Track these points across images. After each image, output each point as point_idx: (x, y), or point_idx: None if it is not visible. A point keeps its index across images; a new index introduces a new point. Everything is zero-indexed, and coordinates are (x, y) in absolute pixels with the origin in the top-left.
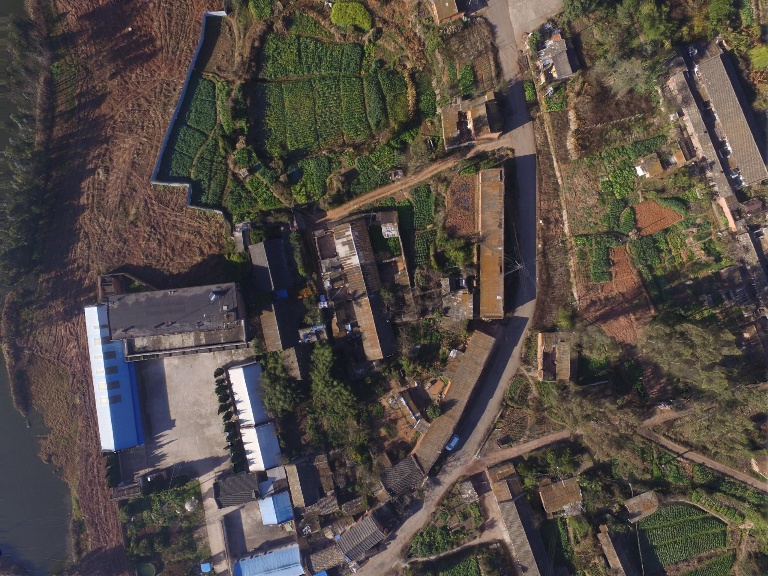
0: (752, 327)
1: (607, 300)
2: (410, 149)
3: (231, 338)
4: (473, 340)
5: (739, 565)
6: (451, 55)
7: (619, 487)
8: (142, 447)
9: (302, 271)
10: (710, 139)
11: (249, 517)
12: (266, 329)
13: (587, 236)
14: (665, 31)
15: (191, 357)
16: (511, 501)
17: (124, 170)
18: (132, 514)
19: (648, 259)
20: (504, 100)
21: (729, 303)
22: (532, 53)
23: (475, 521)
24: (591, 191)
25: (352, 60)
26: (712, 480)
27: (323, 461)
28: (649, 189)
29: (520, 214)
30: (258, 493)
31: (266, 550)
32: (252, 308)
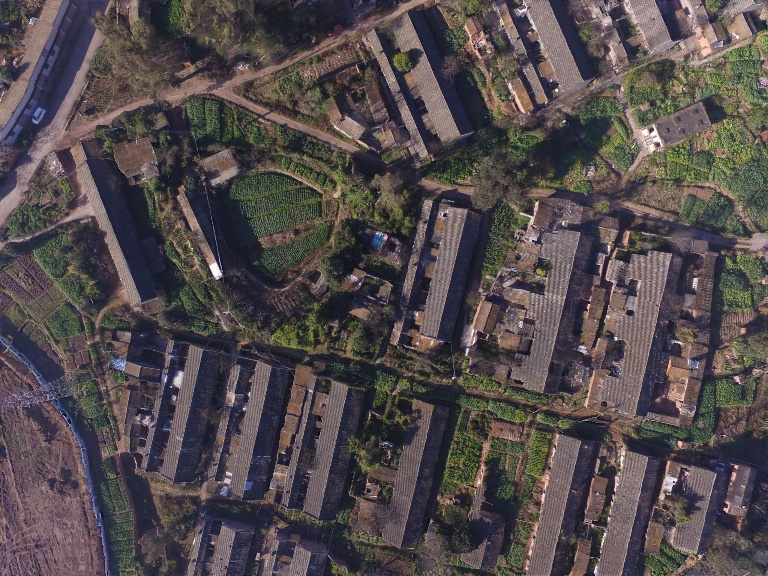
0: None
1: None
2: None
3: None
4: (47, 3)
5: None
6: None
7: (188, 140)
8: None
9: None
10: None
11: None
12: None
13: None
14: None
15: None
16: (83, 161)
17: None
18: None
19: None
20: None
21: None
22: None
23: (66, 197)
24: None
25: None
26: (294, 140)
27: None
28: None
29: None
30: None
31: None
32: None
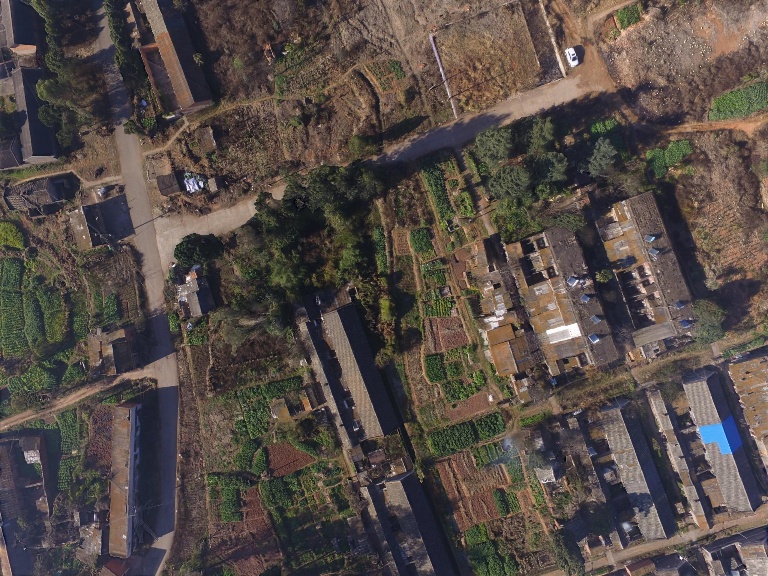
0: None
1: (238, 540)
2: (11, 403)
3: None
4: (101, 575)
5: None
6: (97, 282)
7: None
8: None
9: None
10: (331, 392)
11: None
12: None
13: (219, 475)
14: (291, 279)
15: None
16: None
17: None
18: None
19: (278, 502)
20: (148, 330)
21: (352, 553)
22: (171, 288)
23: None
24: (226, 429)
25: (12, 275)
26: None
27: None
28: (284, 430)
29: (161, 445)
30: None
31: None
32: None
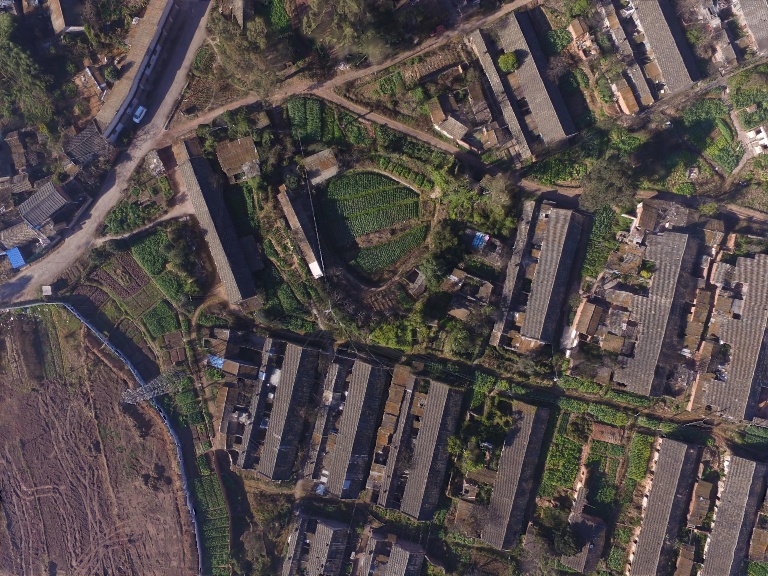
0: None
1: None
2: None
3: None
4: (151, 3)
5: (431, 235)
6: None
7: (291, 139)
8: None
9: None
10: None
11: None
12: None
13: None
14: None
15: None
16: None
17: None
18: None
19: None
20: None
21: None
22: None
23: (165, 195)
24: None
25: None
26: (394, 140)
27: (14, 137)
28: None
29: None
30: None
31: None
32: None
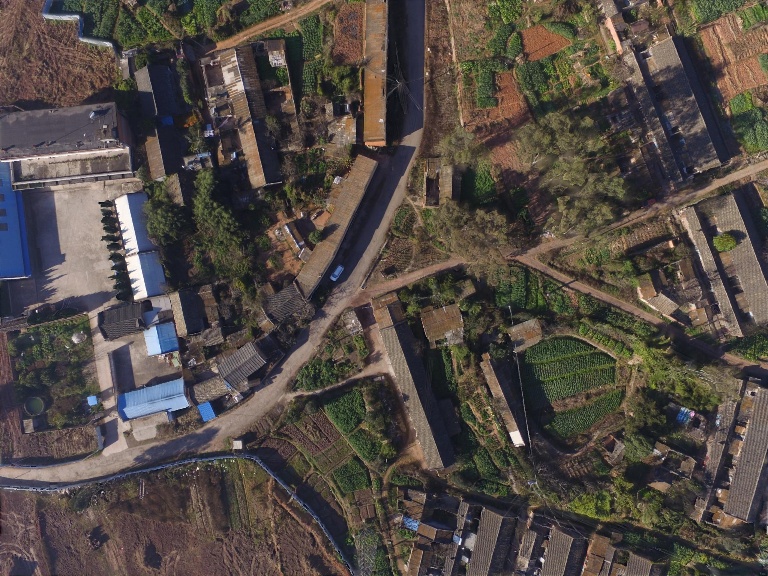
0: (637, 150)
1: (493, 126)
2: None
3: (117, 167)
4: (356, 165)
5: (627, 401)
6: None
7: (499, 311)
8: (32, 282)
9: (187, 97)
10: None
11: (138, 353)
12: (150, 156)
13: (473, 61)
14: None
15: (81, 191)
16: (391, 326)
17: (19, 6)
18: (21, 347)
19: (534, 84)
20: None
21: (615, 126)
22: None
23: (360, 354)
24: (478, 16)
25: None
26: (598, 310)
27: (207, 291)
28: None
29: (408, 42)
30: (142, 322)
31: (154, 385)
32: (140, 140)
